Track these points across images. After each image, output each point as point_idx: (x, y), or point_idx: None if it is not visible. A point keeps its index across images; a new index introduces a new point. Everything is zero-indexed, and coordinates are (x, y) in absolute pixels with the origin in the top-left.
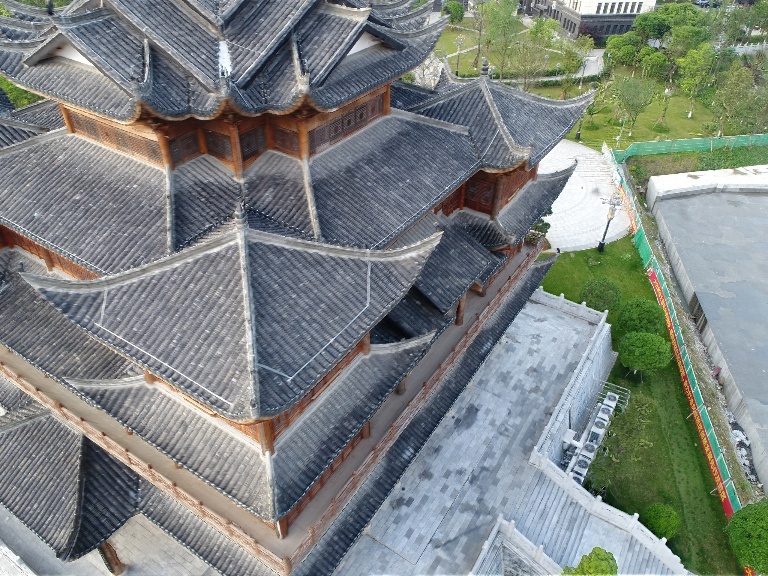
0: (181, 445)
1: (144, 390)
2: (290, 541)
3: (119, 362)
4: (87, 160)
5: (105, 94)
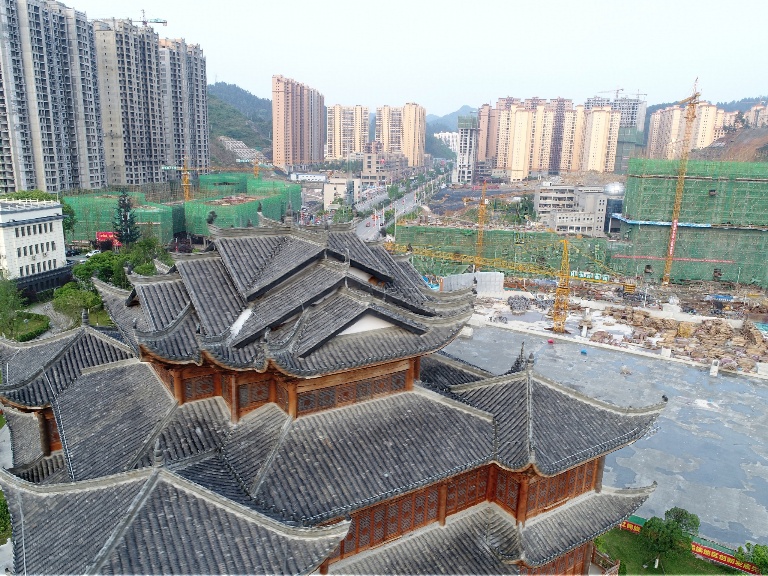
0: (575, 533)
1: (526, 533)
2: (591, 572)
3: (478, 552)
4: (346, 423)
5: (398, 343)
